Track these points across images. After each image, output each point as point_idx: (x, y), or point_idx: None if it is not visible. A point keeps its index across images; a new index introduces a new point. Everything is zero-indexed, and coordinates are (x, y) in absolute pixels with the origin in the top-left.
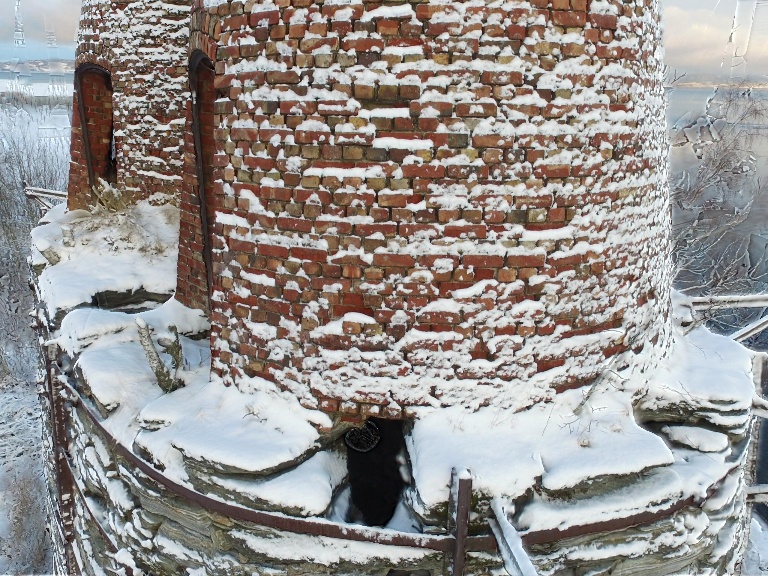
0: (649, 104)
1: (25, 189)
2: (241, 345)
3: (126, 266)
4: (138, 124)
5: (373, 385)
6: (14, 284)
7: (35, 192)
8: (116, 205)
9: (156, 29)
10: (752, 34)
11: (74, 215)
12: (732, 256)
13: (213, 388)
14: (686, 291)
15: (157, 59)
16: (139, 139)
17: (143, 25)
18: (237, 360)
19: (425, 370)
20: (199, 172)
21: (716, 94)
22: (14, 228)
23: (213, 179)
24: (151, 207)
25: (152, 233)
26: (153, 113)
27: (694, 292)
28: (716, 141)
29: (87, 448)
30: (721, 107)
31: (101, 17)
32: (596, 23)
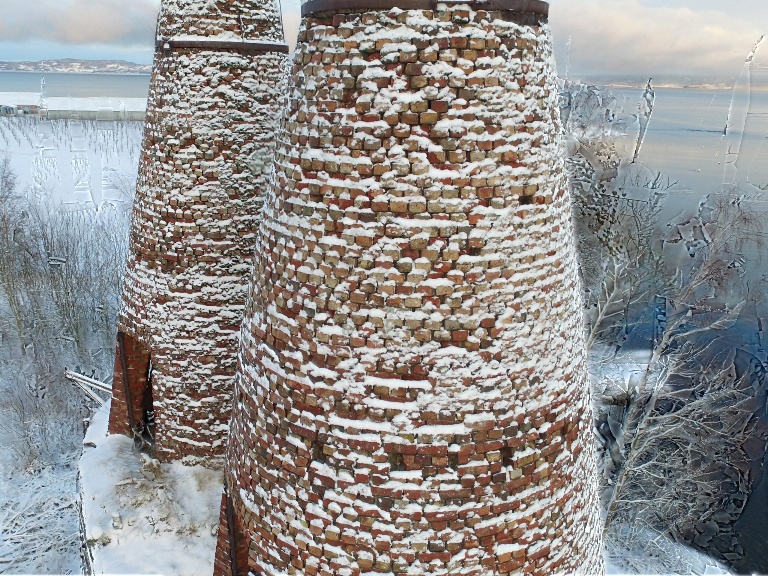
0: (580, 573)
1: (66, 372)
2: None
3: (166, 554)
4: (174, 400)
5: None
6: (39, 361)
7: (75, 377)
8: (155, 473)
9: (190, 325)
10: (743, 142)
11: (115, 442)
12: (719, 366)
13: None
14: (676, 393)
15: (191, 349)
16: (174, 411)
17: (179, 321)
18: None
19: None
20: (231, 541)
21: (708, 200)
22: (38, 297)
23: (242, 541)
24: (184, 468)
25: (186, 509)
26: (187, 392)
27: (684, 394)
28: (708, 242)
29: None
30: (712, 213)
31: (143, 305)
32: (533, 559)
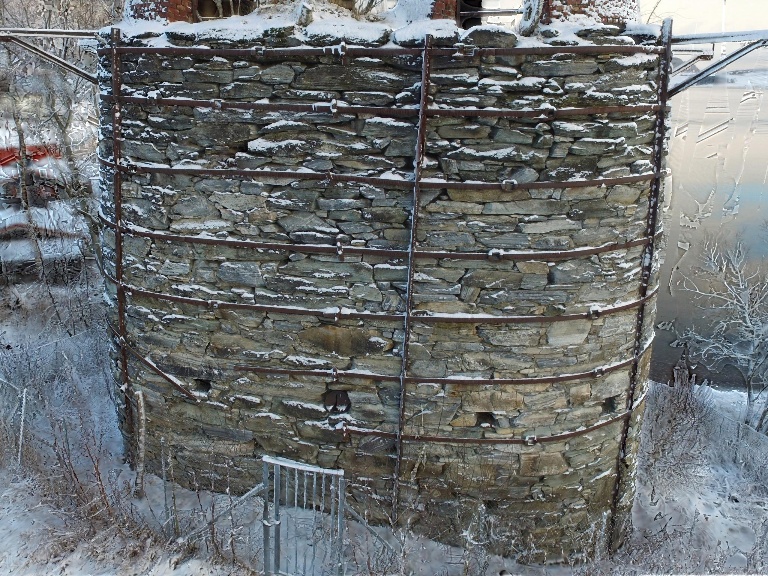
0: None
1: None
2: (568, 0)
3: None
4: None
5: (616, 10)
6: None
7: (12, 32)
8: None
9: None
10: None
11: (184, 24)
12: None
13: (558, 23)
14: None
15: None
16: None
17: None
18: (567, 8)
19: (625, 5)
20: None
21: None
22: None
23: None
24: None
25: None
26: None
27: None
28: None
29: (483, 79)
30: None
31: None
32: None
